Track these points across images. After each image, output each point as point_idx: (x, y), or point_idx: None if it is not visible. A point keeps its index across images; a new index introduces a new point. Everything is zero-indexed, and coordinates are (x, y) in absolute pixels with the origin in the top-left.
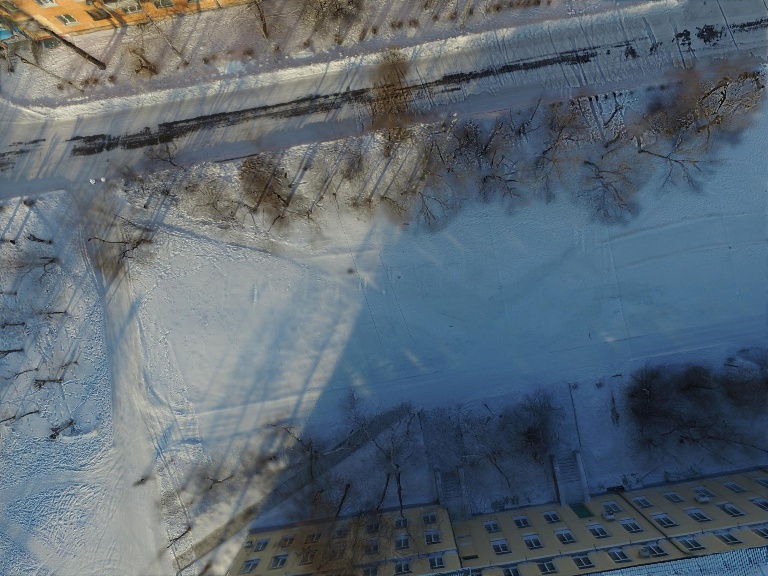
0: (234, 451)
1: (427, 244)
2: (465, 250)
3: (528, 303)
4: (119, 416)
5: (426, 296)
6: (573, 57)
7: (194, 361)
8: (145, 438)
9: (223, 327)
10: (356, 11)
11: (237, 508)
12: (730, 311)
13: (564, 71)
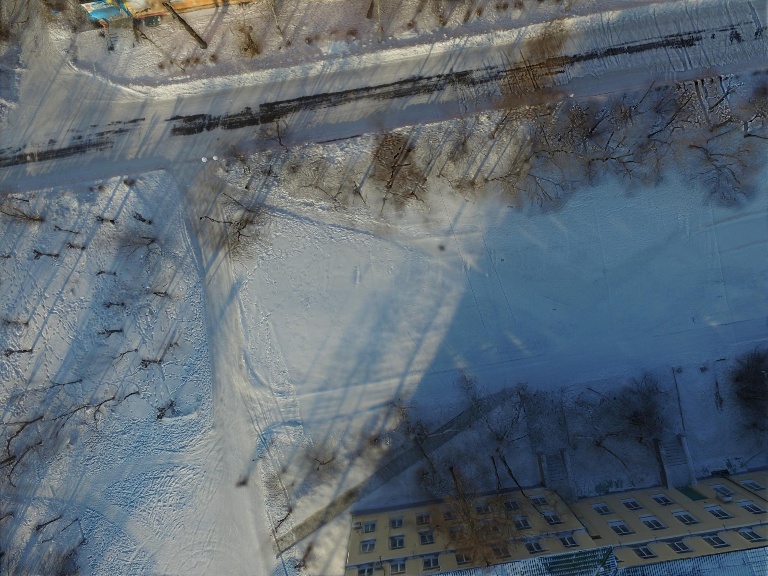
0: (335, 433)
1: (531, 227)
2: (569, 233)
3: (632, 287)
4: (219, 398)
5: (529, 279)
6: (678, 41)
7: (296, 343)
8: (245, 420)
9: (325, 309)
10: None
11: (338, 490)
12: None
13: (669, 55)
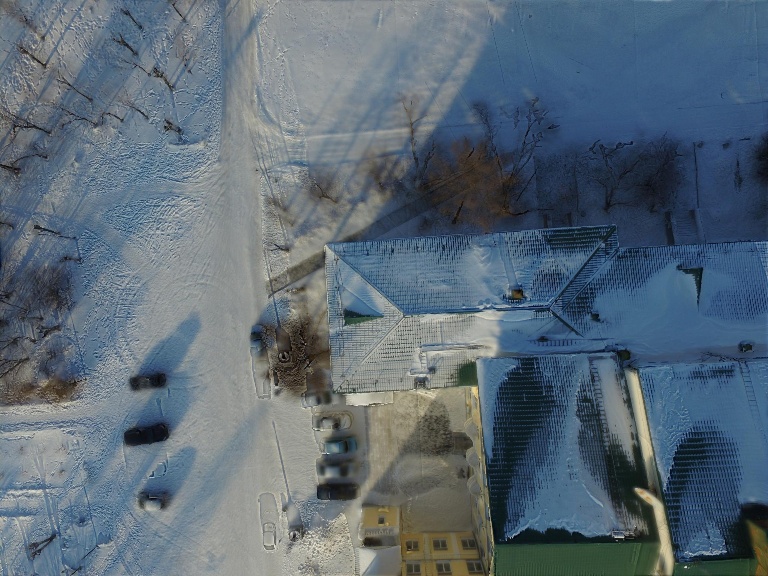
0: (340, 178)
1: None
2: None
3: (661, 56)
4: (227, 132)
5: (556, 38)
6: None
7: (310, 82)
8: (251, 157)
9: (343, 49)
10: None
11: (338, 235)
12: None
13: None
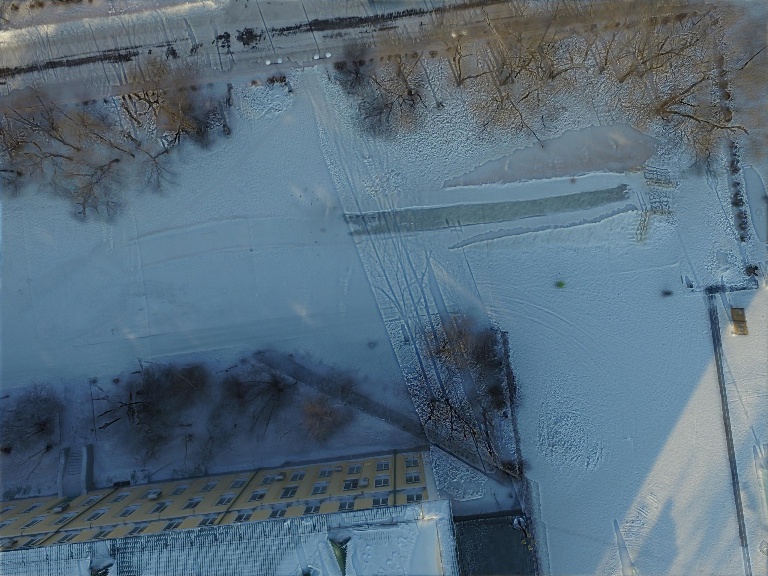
0: None
1: None
2: None
3: (56, 297)
4: None
5: None
6: (115, 55)
7: None
8: None
9: None
10: None
11: None
12: (249, 313)
13: (105, 69)
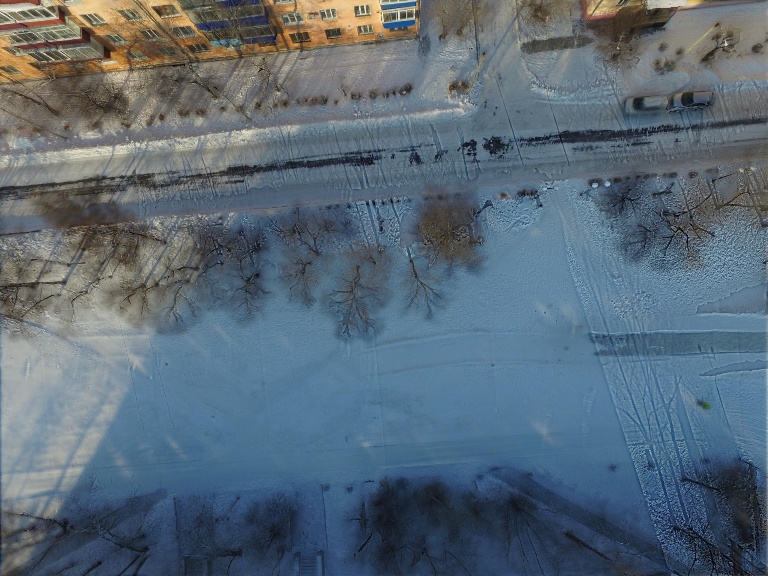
0: None
1: (196, 334)
2: (232, 343)
3: (290, 401)
4: None
5: (191, 385)
6: (357, 158)
7: None
8: None
9: None
10: (147, 95)
11: None
12: (487, 428)
13: (347, 172)
